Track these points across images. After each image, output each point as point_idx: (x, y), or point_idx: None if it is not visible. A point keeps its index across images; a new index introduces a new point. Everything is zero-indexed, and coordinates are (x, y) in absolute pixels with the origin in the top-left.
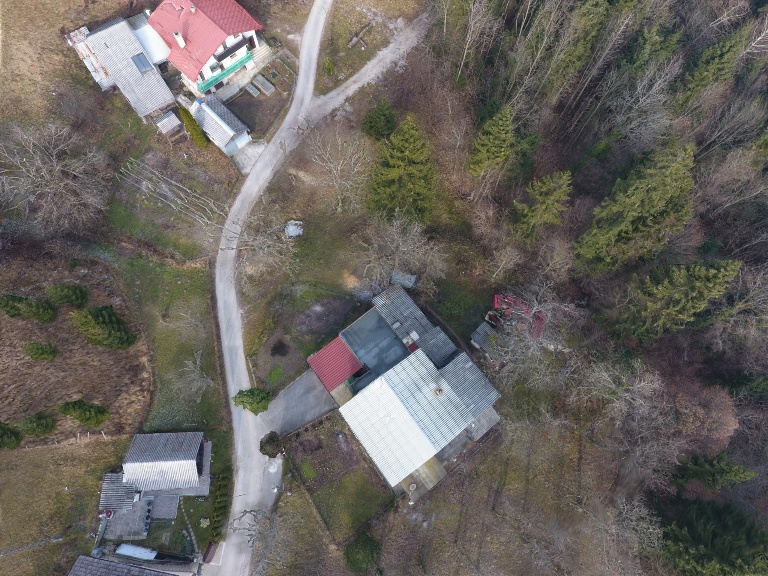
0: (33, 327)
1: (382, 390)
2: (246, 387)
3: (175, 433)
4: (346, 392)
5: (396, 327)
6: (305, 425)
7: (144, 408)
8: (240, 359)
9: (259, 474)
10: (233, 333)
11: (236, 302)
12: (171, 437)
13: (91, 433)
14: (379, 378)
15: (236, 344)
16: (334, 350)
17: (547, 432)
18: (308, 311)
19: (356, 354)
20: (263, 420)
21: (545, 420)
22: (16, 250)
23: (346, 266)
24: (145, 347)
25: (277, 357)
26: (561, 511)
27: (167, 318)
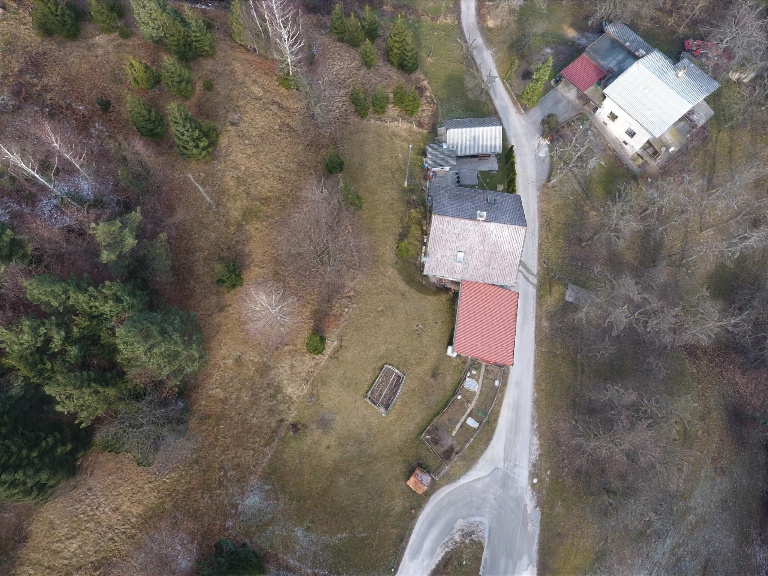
0: (348, 48)
1: (639, 71)
2: (508, 101)
3: (474, 118)
4: (597, 91)
5: (628, 45)
6: (561, 124)
7: (433, 115)
8: (498, 83)
9: (532, 158)
10: (488, 66)
11: (484, 46)
12: (472, 119)
13: (407, 121)
14: (636, 62)
15: (492, 73)
16: (581, 64)
17: (742, 135)
18: (542, 52)
19: (602, 62)
20: (527, 122)
21: (762, 94)
22: (305, 9)
23: (564, 21)
24: (422, 76)
25: (527, 80)
26: (759, 192)
27: (433, 57)
